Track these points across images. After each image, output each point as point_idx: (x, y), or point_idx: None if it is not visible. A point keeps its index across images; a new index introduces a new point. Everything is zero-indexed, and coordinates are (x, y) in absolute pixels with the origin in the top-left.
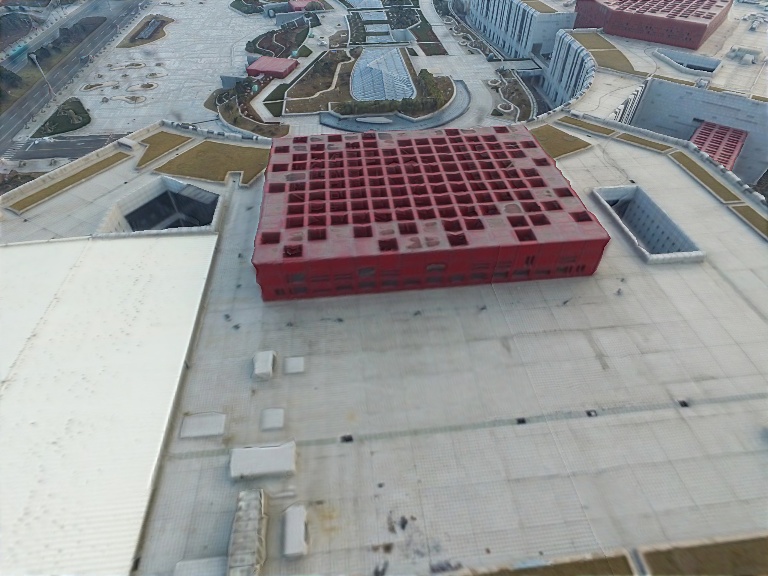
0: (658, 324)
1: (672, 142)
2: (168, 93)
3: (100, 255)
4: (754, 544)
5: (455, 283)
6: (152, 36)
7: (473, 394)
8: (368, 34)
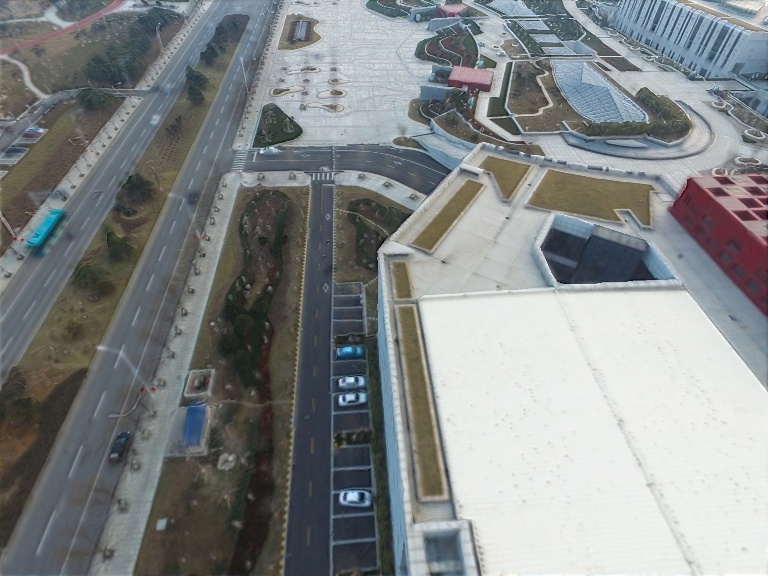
0: None
1: None
2: (363, 102)
3: (586, 313)
4: None
5: None
6: (309, 38)
7: None
8: (541, 45)
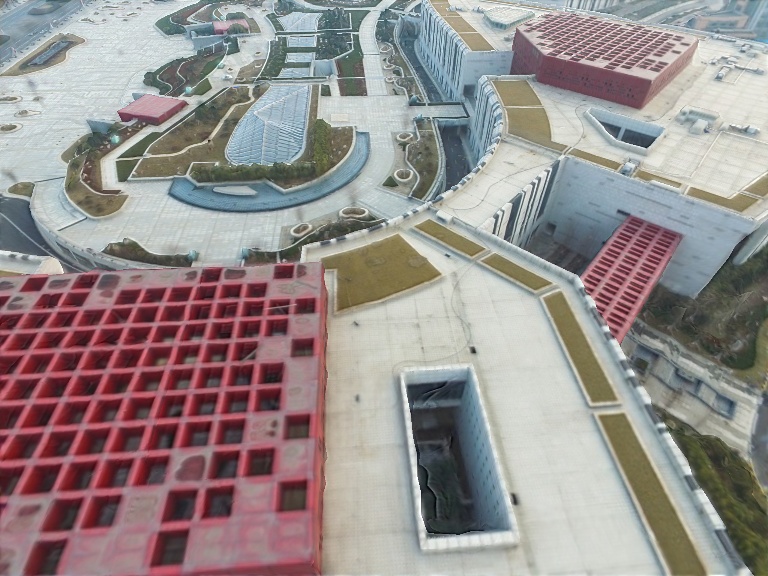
0: None
1: (555, 272)
2: (28, 138)
3: None
4: None
5: None
6: (48, 61)
7: None
8: (286, 65)
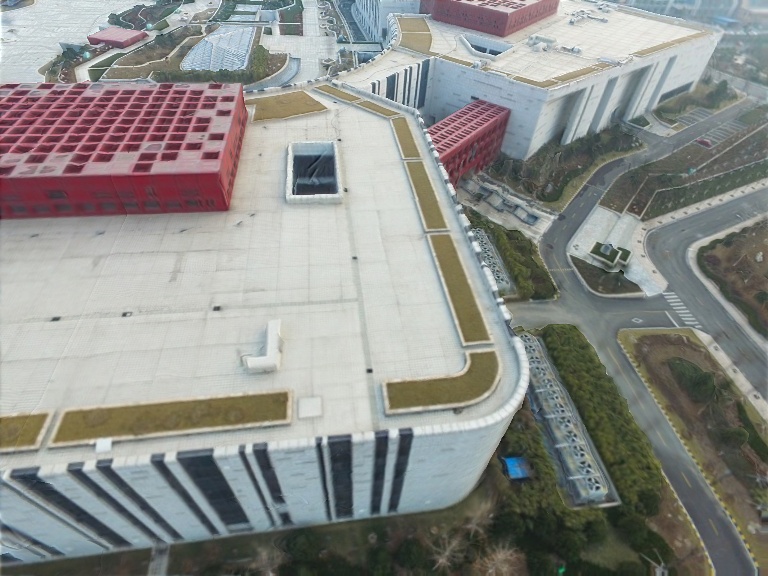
0: (252, 249)
1: (404, 110)
2: (7, 58)
3: None
4: (170, 406)
5: (90, 213)
6: (18, 4)
7: (30, 298)
8: (235, 13)
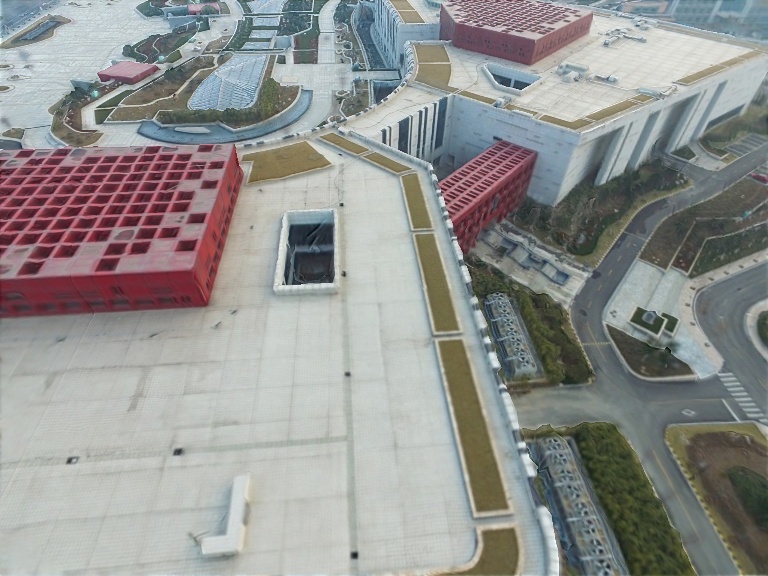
0: (228, 362)
1: (416, 163)
2: (19, 96)
3: None
4: None
5: (53, 312)
6: (37, 37)
7: None
8: (249, 40)
